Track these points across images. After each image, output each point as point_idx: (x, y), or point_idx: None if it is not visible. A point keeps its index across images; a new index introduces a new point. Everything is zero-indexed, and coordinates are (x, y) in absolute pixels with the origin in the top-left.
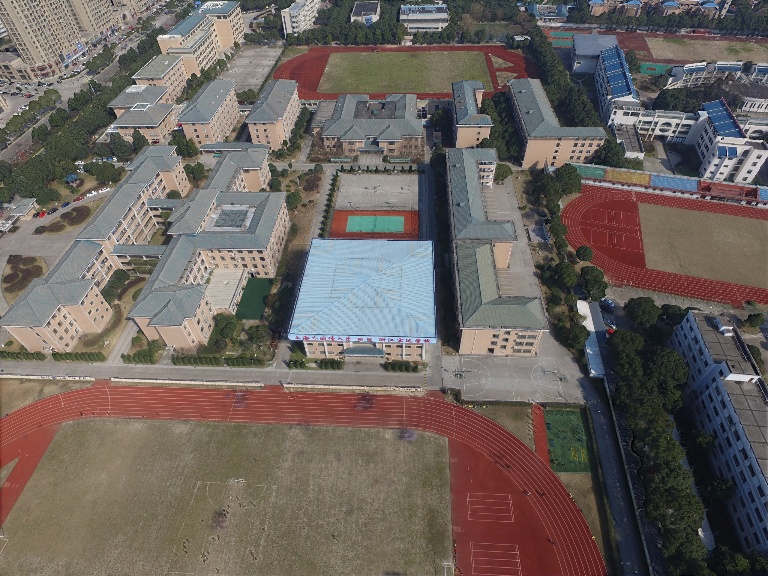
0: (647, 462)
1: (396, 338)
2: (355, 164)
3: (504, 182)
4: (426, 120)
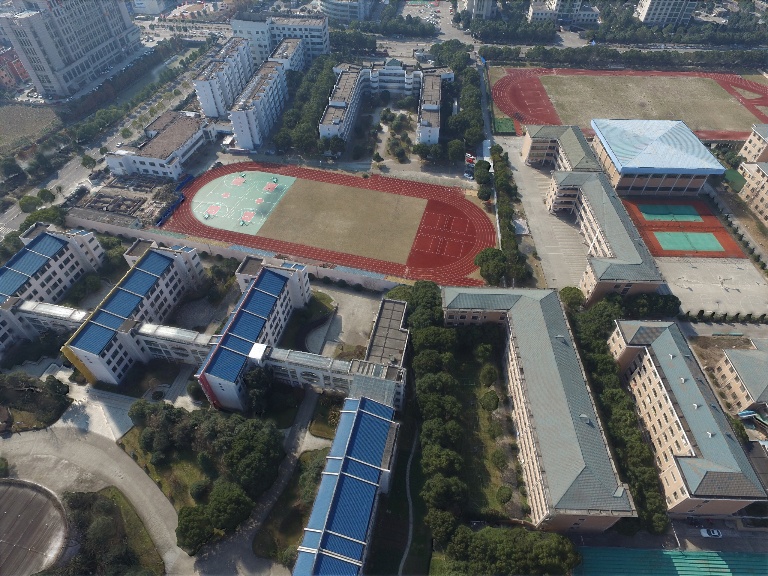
0: None
1: None
2: None
3: None
4: None
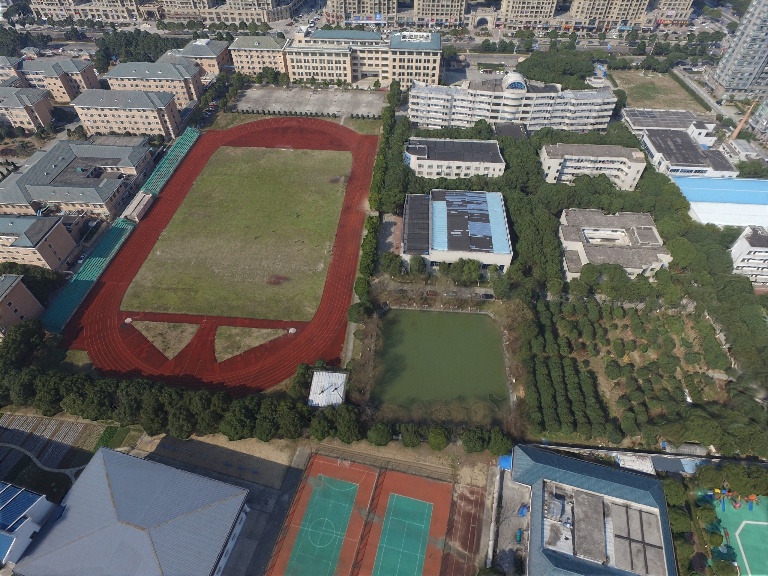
0: None
1: None
2: None
3: None
4: None
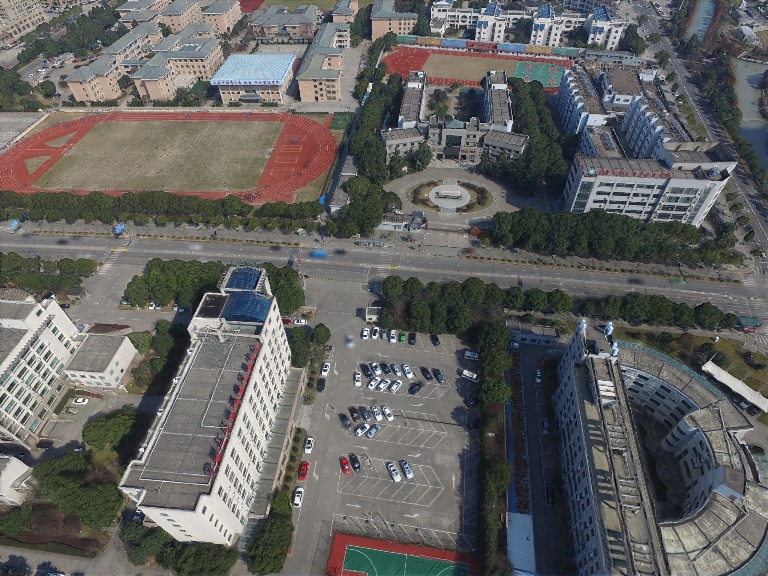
0: None
1: (262, 81)
2: None
3: (358, 46)
4: (322, 20)
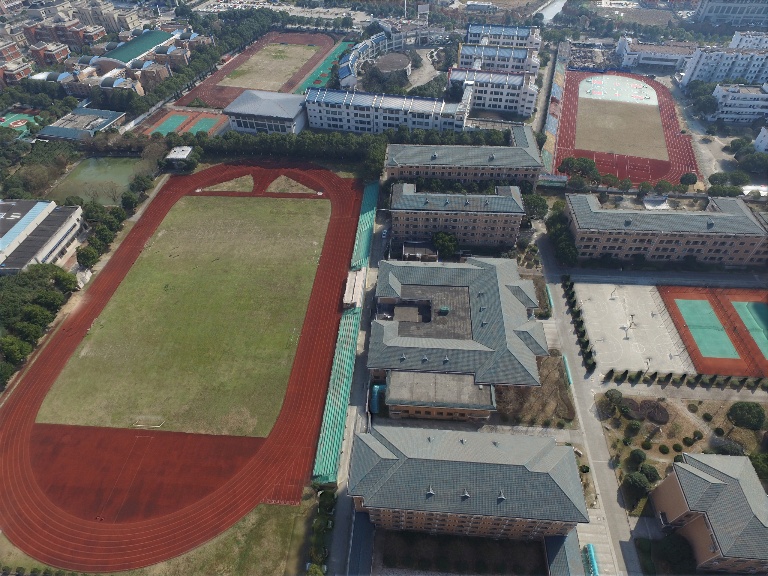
0: None
1: None
2: (564, 353)
3: None
4: None
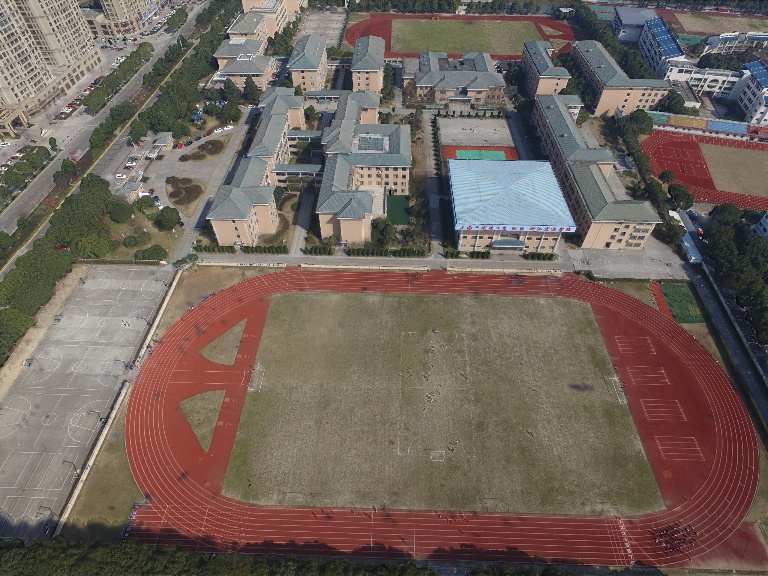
0: (755, 307)
1: (544, 227)
2: (447, 110)
3: (582, 126)
4: None
